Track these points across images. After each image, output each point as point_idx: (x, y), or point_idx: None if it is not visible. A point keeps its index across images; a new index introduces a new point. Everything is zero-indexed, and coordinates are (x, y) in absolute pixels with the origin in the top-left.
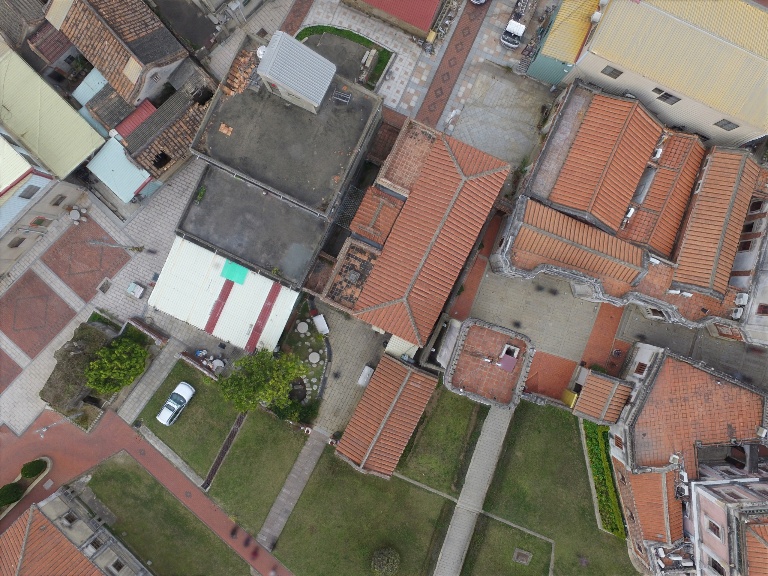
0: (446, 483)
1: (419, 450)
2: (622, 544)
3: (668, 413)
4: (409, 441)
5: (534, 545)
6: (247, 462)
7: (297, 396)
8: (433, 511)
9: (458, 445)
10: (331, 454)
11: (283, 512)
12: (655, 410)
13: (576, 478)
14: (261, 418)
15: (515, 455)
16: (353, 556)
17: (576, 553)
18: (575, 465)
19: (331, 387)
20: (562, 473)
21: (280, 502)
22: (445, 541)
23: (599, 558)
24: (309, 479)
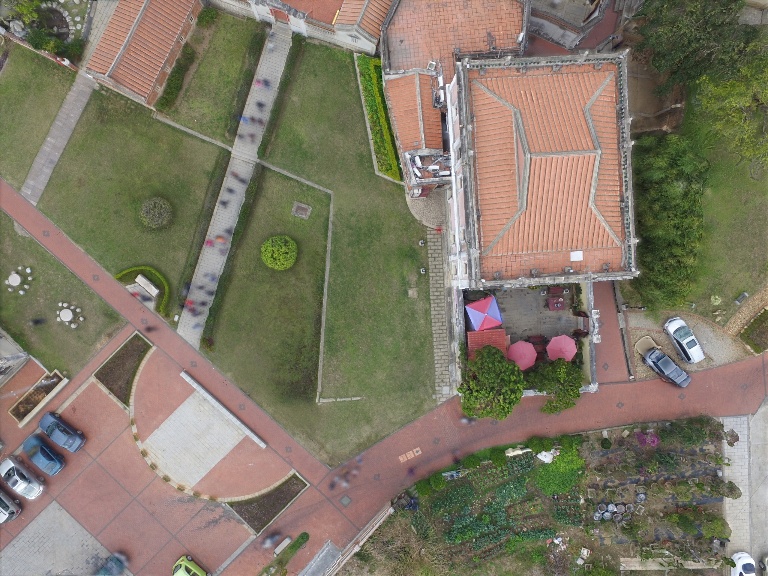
0: (219, 130)
1: (190, 94)
2: (400, 191)
3: (426, 19)
4: (175, 77)
5: (313, 197)
6: (9, 109)
7: (62, 40)
8: (207, 162)
9: (231, 89)
10: (99, 101)
11: (48, 162)
12: (412, 15)
13: (353, 123)
14: (23, 62)
15: (291, 100)
16: (124, 210)
17: (354, 203)
18: (352, 110)
19: (97, 28)
20: (339, 118)
21: (44, 151)
22: (220, 194)
23: (377, 206)
24: (75, 127)
